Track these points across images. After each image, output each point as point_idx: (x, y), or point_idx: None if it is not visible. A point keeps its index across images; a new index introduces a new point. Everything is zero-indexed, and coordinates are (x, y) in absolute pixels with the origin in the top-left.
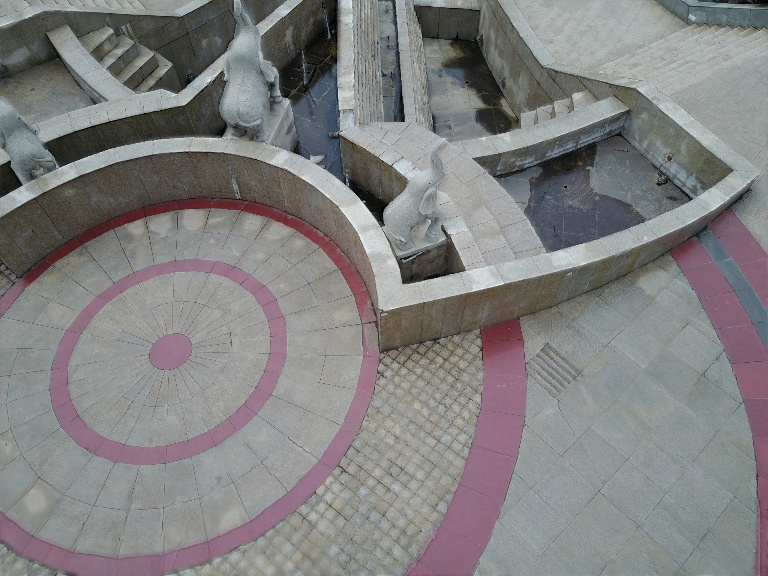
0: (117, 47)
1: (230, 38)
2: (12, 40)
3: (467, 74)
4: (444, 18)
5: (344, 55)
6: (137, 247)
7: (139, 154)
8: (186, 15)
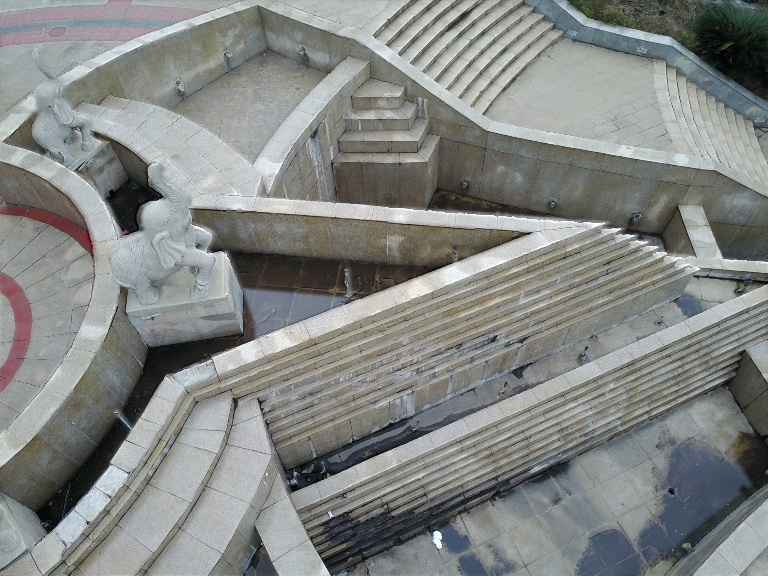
0: (394, 110)
1: (536, 185)
2: (321, 43)
3: (690, 484)
4: (766, 402)
5: (331, 318)
6: (47, 265)
7: (84, 208)
8: (493, 133)
